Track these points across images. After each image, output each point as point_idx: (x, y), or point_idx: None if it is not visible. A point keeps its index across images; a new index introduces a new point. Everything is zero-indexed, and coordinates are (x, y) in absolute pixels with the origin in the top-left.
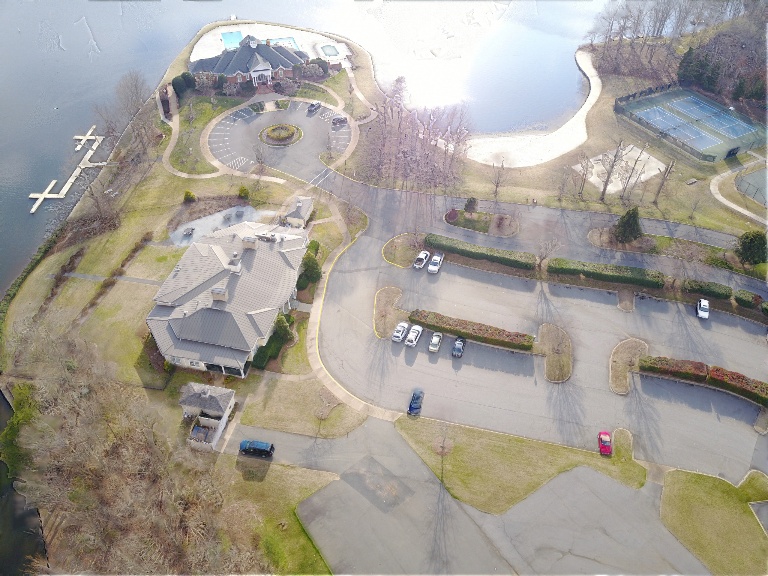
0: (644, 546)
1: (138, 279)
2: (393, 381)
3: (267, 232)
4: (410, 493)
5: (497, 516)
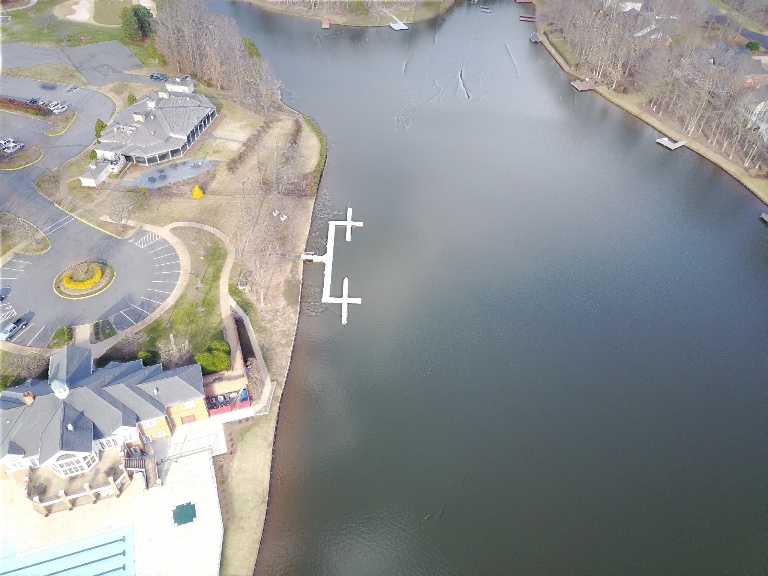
0: (6, 53)
1: (232, 141)
2: (79, 96)
3: (128, 142)
4: (93, 67)
5: (60, 61)
